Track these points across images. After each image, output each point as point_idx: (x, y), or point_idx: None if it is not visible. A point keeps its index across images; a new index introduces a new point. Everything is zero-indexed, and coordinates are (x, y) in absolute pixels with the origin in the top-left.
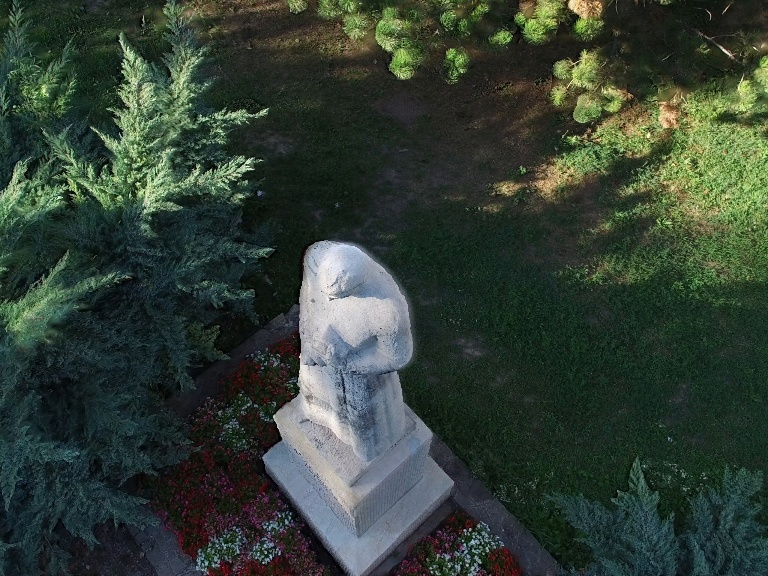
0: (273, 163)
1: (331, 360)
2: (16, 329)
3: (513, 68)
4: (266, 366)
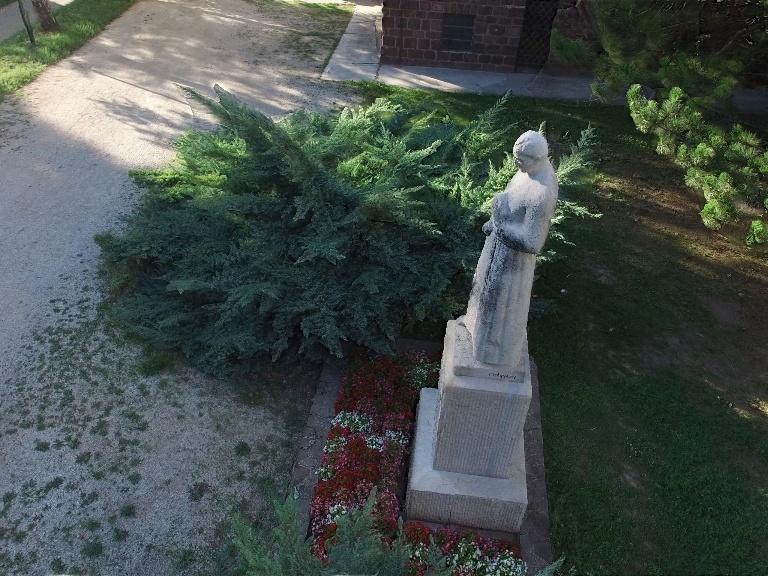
0: (589, 282)
1: (495, 212)
2: (371, 199)
3: None
4: None
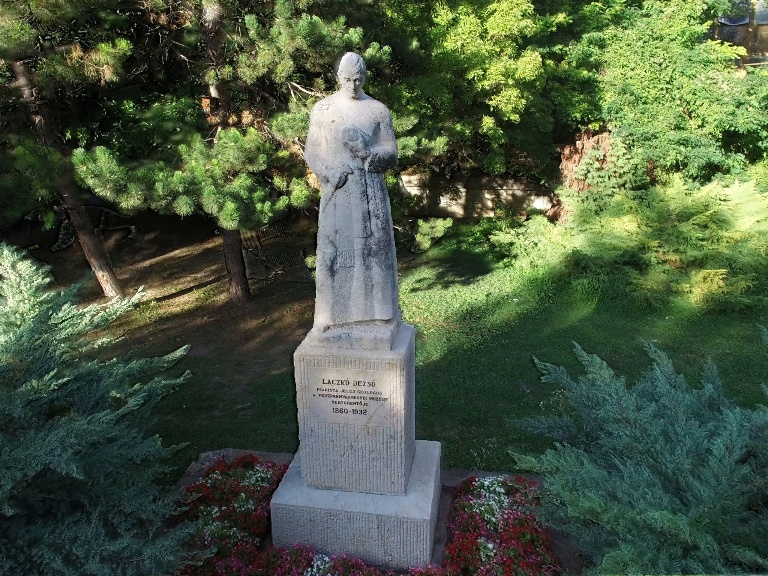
0: None
1: (363, 142)
2: (5, 364)
3: (263, 312)
4: (211, 483)
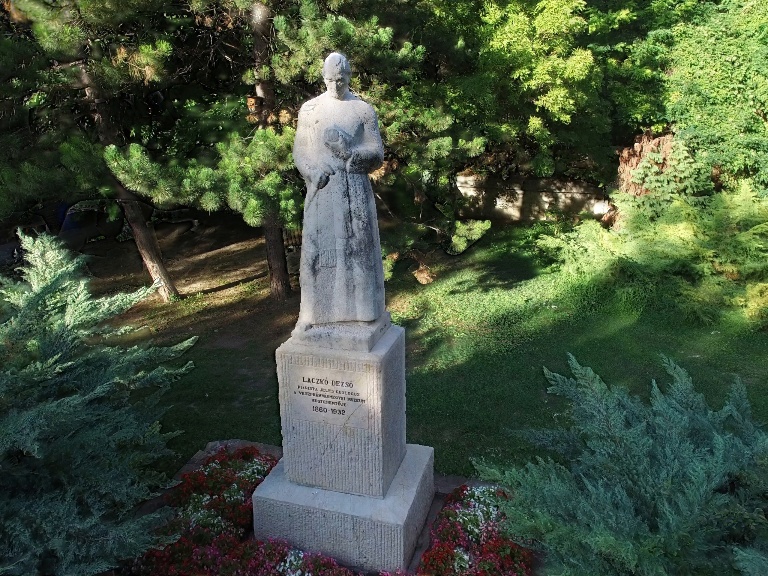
0: (130, 393)
1: (343, 143)
2: None
3: None
4: (209, 472)
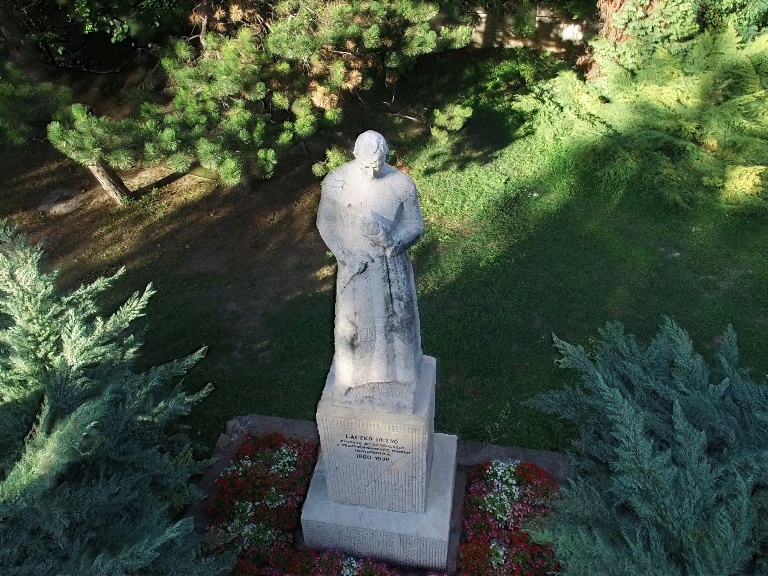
0: None
1: (384, 234)
2: (36, 476)
3: (271, 204)
4: (242, 471)
